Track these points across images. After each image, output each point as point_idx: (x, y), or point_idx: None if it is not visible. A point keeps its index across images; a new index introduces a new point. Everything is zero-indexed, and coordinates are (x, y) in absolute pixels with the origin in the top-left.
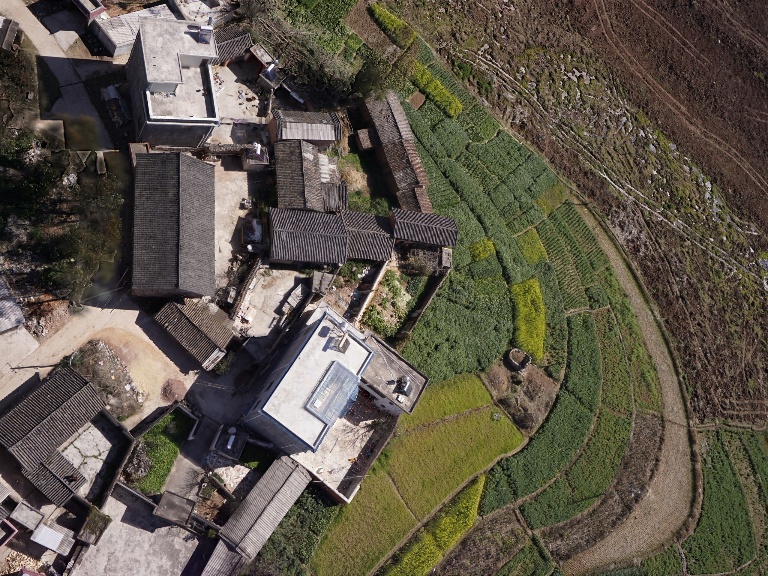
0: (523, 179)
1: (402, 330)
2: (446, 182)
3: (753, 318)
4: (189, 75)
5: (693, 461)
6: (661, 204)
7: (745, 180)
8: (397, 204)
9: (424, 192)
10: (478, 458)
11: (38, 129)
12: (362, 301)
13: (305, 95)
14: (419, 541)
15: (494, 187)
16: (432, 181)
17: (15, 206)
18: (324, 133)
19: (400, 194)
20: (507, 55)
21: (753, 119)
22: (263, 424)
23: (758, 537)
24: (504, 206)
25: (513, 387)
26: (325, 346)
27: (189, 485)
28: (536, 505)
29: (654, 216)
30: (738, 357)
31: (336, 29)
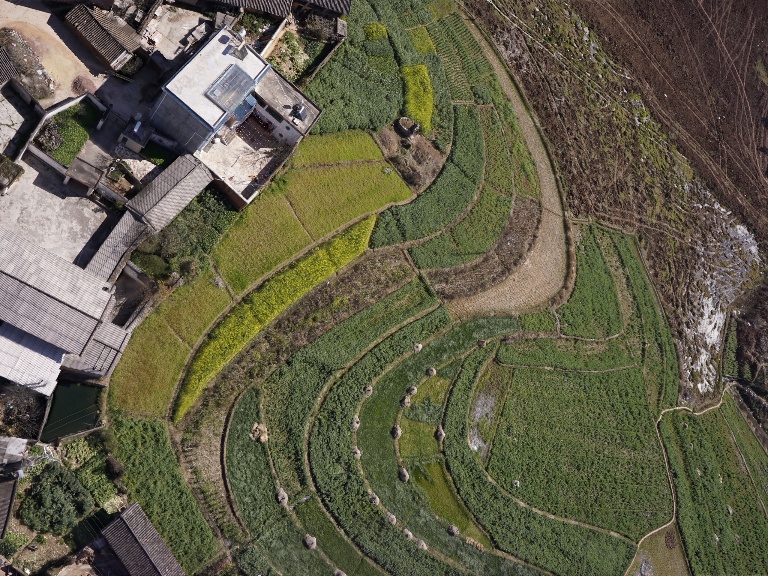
0: None
1: None
2: None
3: (625, 145)
4: None
5: (567, 244)
6: (543, 36)
7: (620, 32)
8: None
9: None
10: (370, 201)
11: None
12: (262, 49)
13: None
14: None
15: None
16: None
17: None
18: None
19: None
20: None
21: None
22: (167, 113)
23: (626, 318)
24: (396, 2)
25: (403, 150)
26: (225, 51)
27: (98, 167)
28: (423, 249)
29: (536, 44)
30: (611, 173)
31: None
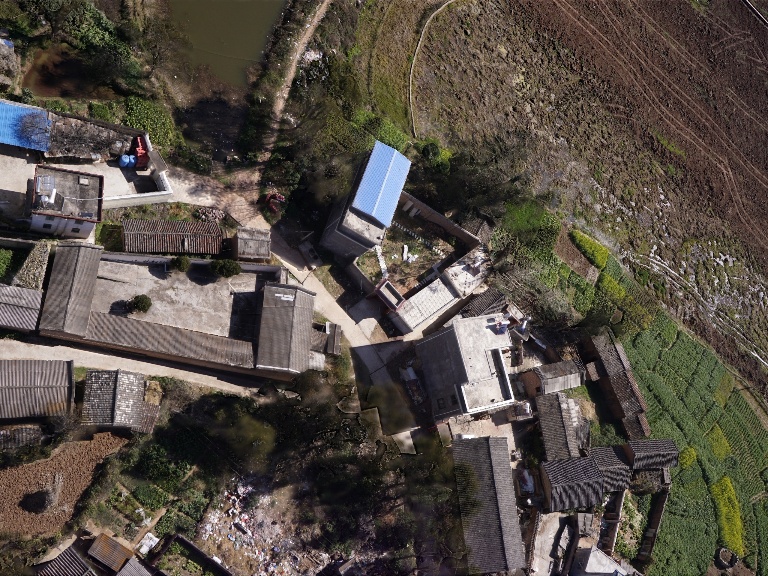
0: (704, 378)
1: (641, 550)
2: (652, 396)
3: None
4: None
5: None
6: None
7: None
8: (623, 429)
9: (643, 415)
10: None
11: None
12: (611, 530)
13: (548, 342)
14: None
15: (684, 391)
16: None
17: (360, 503)
18: (573, 381)
19: (625, 420)
20: (671, 252)
21: None
22: None
23: None
24: (694, 408)
25: None
26: None
27: None
28: None
29: None
30: None
31: (551, 262)
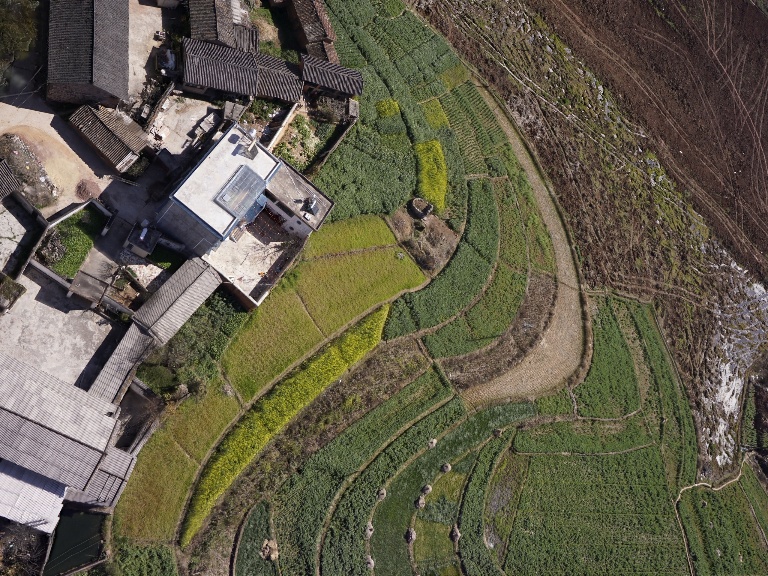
0: (427, 54)
1: None
2: (354, 45)
3: (641, 208)
4: None
5: (584, 319)
6: (557, 98)
7: (634, 88)
8: None
9: (332, 48)
10: (383, 290)
11: None
12: (272, 136)
13: None
14: (326, 353)
15: (399, 57)
16: (340, 42)
17: None
18: None
19: (309, 47)
20: None
21: (642, 36)
22: (175, 219)
23: (643, 393)
24: (409, 75)
25: (416, 232)
26: (234, 151)
27: (103, 276)
28: (437, 337)
29: (550, 107)
30: (626, 238)
31: None
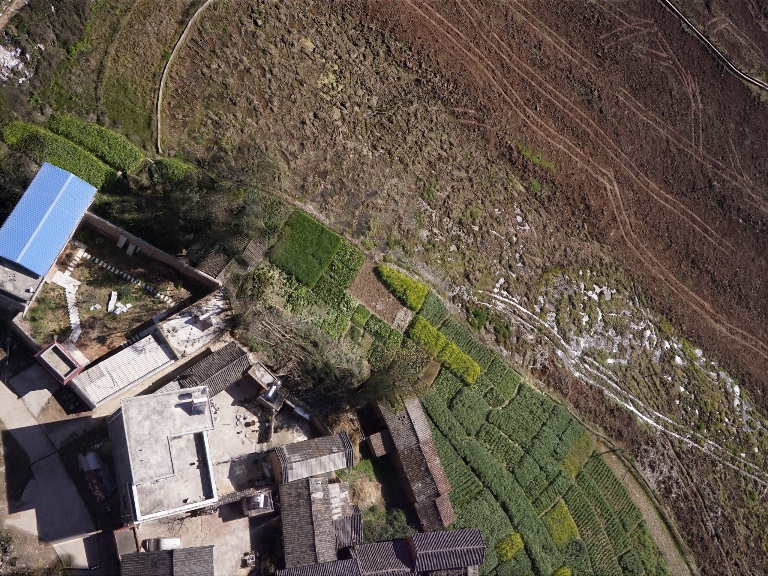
0: (548, 442)
1: None
2: (467, 470)
3: None
4: (181, 446)
5: None
6: (690, 426)
7: None
8: (416, 517)
9: (445, 497)
10: None
11: (6, 527)
12: None
13: (311, 410)
14: None
15: (518, 461)
16: (452, 474)
17: None
18: (334, 463)
19: (419, 505)
20: (524, 286)
21: None
22: None
23: None
24: (530, 482)
25: None
26: None
27: None
28: None
29: (684, 444)
30: None
31: (341, 305)
